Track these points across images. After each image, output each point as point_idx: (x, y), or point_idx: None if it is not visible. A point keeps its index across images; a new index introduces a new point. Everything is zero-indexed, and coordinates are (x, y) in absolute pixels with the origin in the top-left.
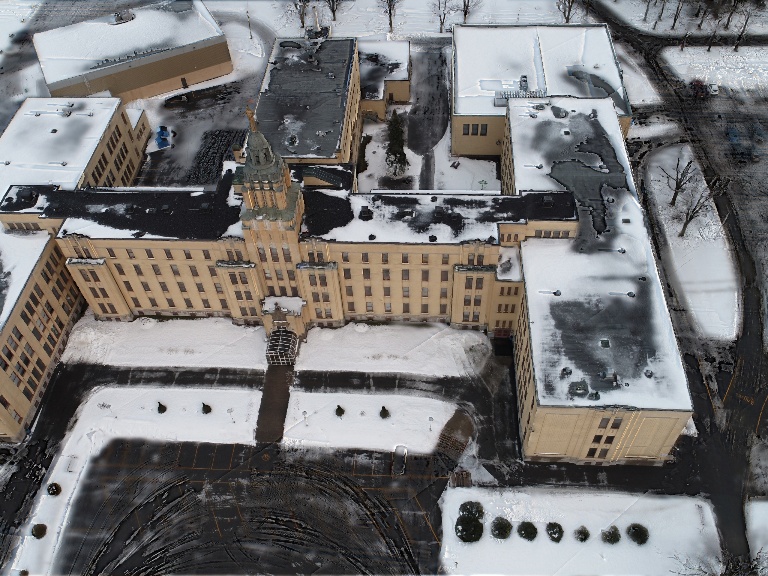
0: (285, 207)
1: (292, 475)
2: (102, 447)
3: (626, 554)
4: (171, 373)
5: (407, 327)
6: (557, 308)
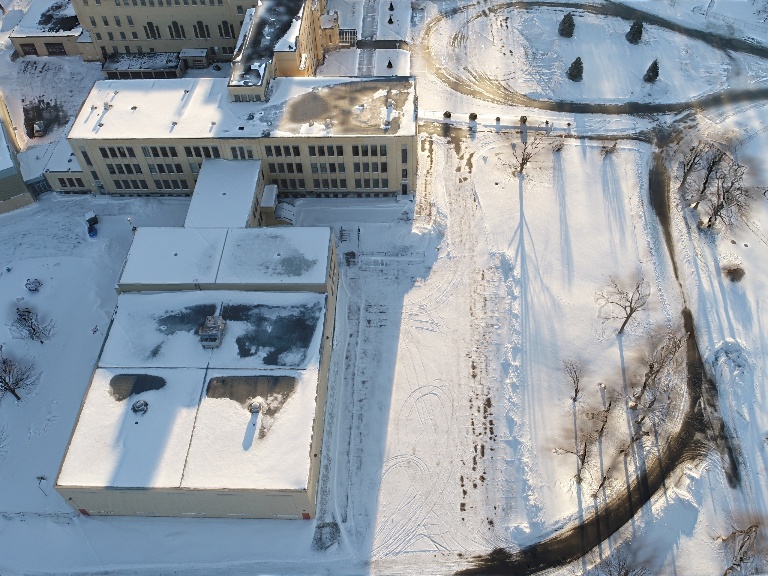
0: None
1: (428, 39)
2: None
3: None
4: None
5: (332, 5)
6: None
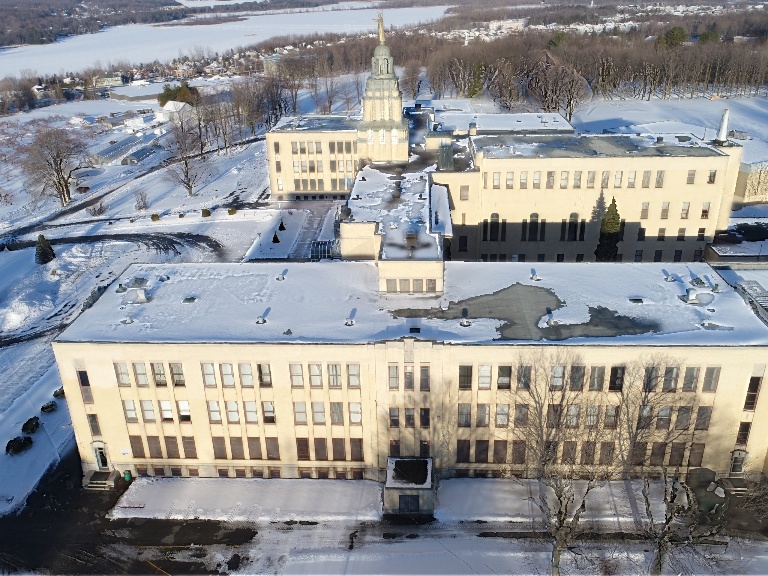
0: (366, 120)
1: None
2: (261, 221)
3: (7, 438)
4: (316, 229)
5: None
6: (258, 278)
